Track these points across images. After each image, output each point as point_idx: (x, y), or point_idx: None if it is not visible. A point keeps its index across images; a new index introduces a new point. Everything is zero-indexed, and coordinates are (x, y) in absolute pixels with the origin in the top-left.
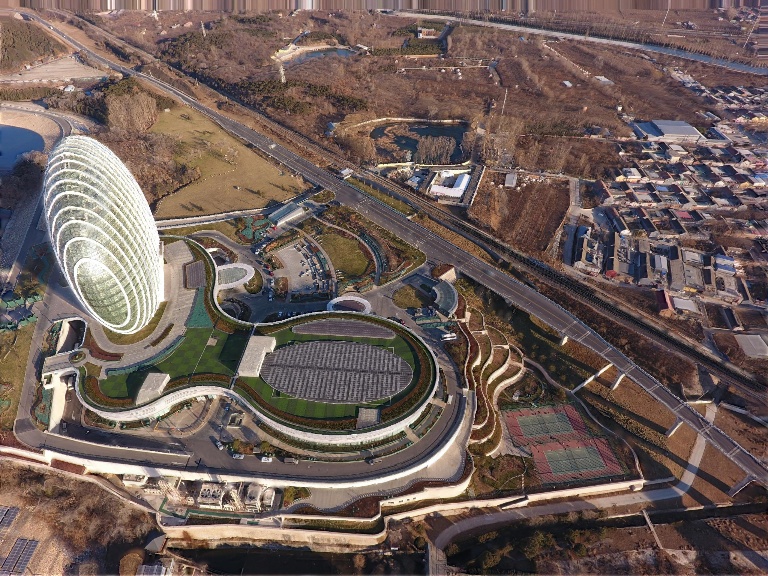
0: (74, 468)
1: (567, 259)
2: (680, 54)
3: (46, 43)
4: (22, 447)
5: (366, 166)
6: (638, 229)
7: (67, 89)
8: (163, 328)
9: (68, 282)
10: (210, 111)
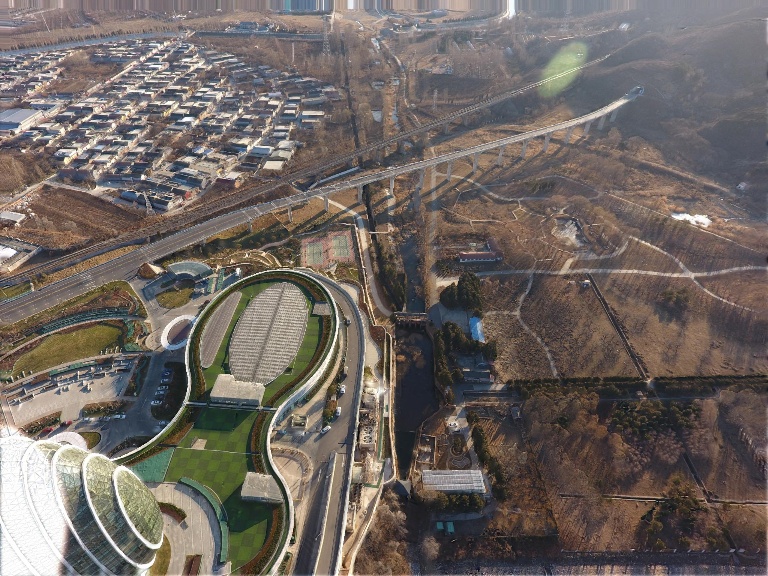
0: None
1: None
2: None
3: None
4: None
5: None
6: (144, 171)
7: None
8: None
9: (99, 563)
10: None
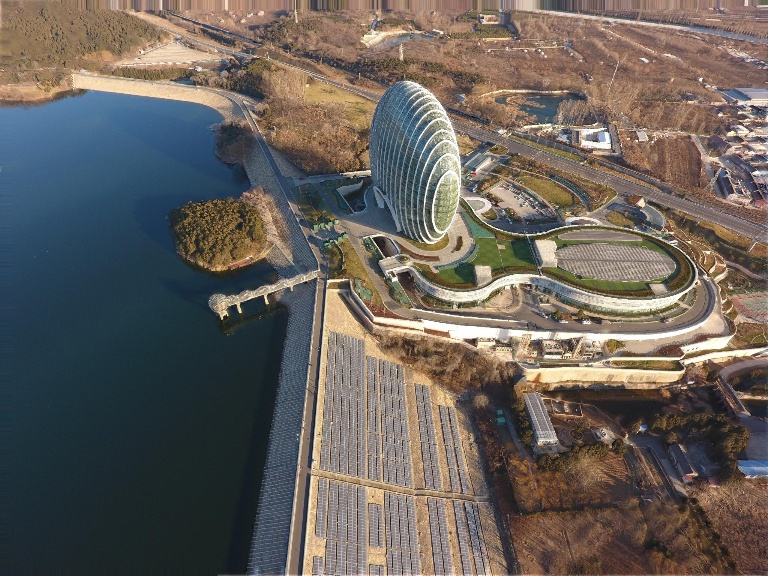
0: (441, 334)
1: (718, 194)
2: (725, 35)
3: (152, 30)
4: (403, 318)
5: (512, 128)
6: (766, 171)
7: (199, 70)
8: (455, 239)
9: (418, 194)
10: (347, 86)
